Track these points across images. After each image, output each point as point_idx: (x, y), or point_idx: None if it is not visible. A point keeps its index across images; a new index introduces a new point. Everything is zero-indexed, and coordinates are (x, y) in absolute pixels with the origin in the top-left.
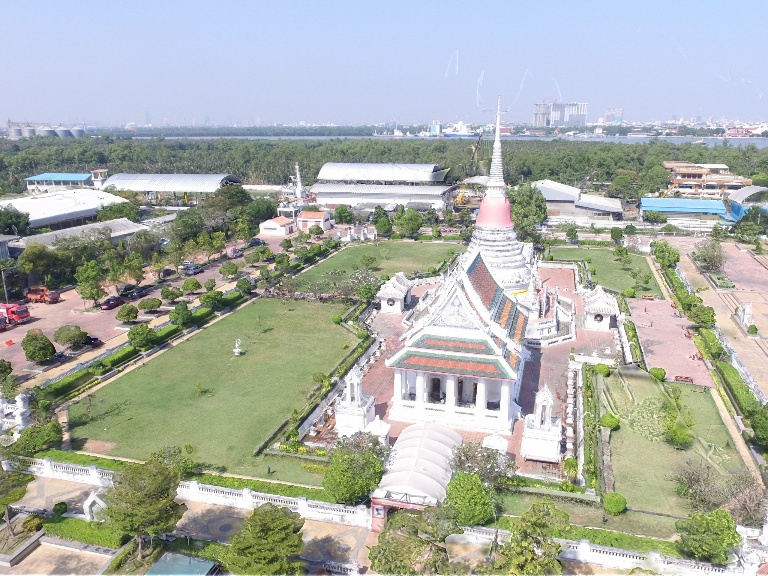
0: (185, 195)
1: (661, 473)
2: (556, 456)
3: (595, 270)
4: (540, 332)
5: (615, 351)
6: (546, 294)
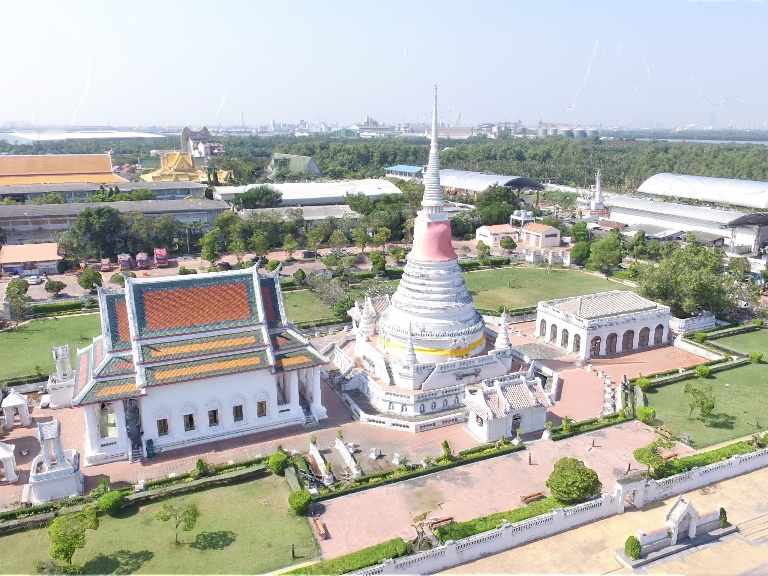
0: (475, 194)
1: (3, 570)
2: (35, 499)
3: (707, 371)
4: (389, 404)
5: (408, 464)
6: (472, 365)
